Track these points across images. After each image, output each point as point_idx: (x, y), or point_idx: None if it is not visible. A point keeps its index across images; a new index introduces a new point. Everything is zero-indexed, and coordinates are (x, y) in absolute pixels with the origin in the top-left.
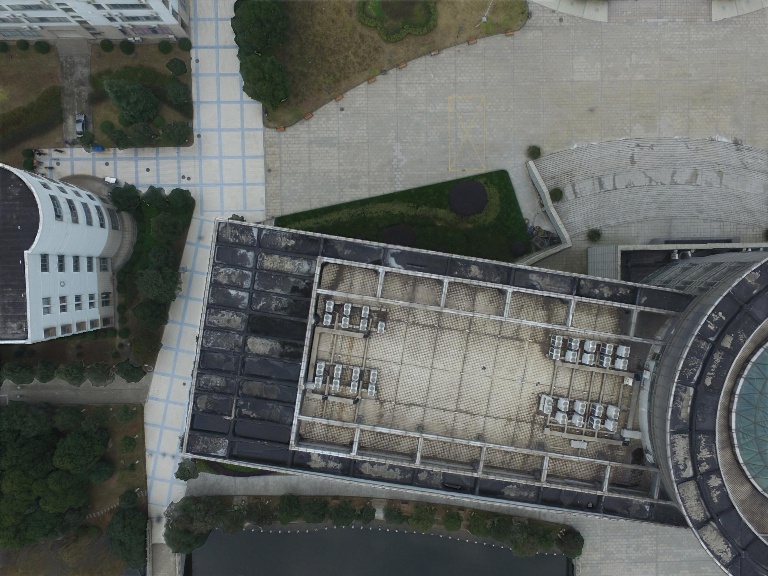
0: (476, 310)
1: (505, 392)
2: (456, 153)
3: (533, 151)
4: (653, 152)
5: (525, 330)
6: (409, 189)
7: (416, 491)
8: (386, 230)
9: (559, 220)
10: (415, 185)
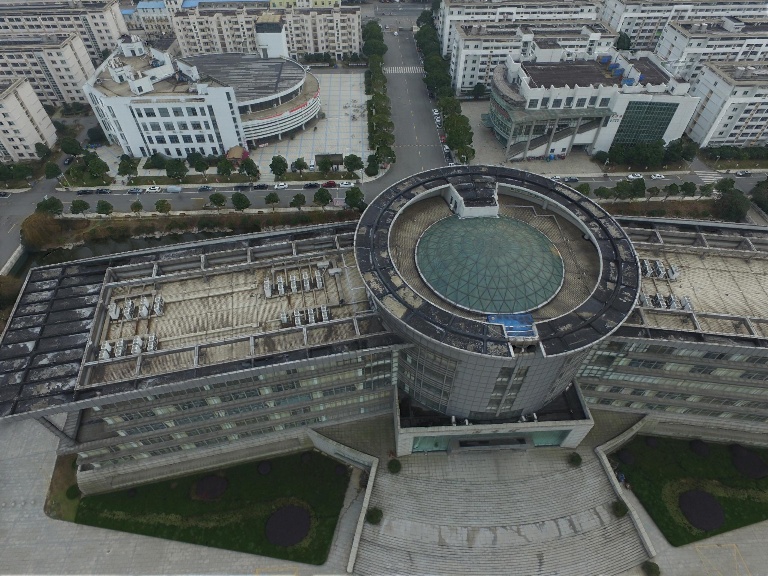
0: (759, 331)
1: (701, 282)
2: (738, 567)
3: (657, 568)
4: (517, 573)
5: (711, 319)
6: (767, 520)
7: (743, 224)
8: (767, 472)
9: (613, 477)
10: (763, 525)
